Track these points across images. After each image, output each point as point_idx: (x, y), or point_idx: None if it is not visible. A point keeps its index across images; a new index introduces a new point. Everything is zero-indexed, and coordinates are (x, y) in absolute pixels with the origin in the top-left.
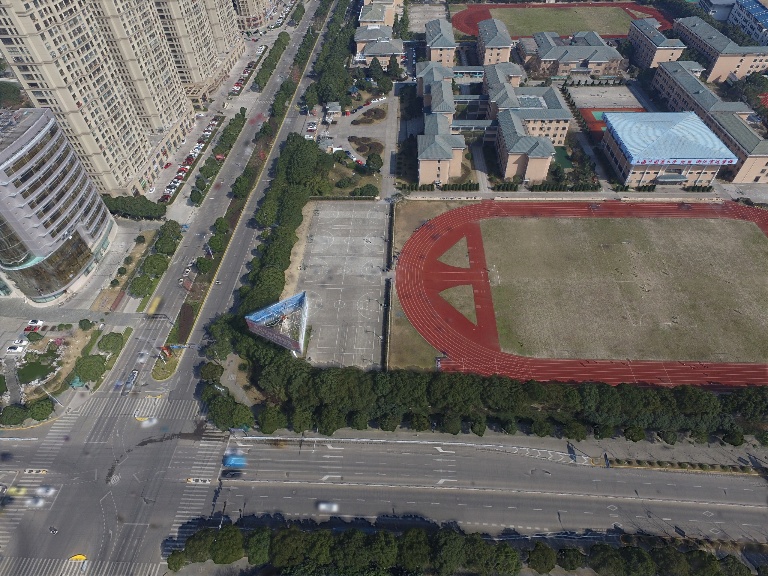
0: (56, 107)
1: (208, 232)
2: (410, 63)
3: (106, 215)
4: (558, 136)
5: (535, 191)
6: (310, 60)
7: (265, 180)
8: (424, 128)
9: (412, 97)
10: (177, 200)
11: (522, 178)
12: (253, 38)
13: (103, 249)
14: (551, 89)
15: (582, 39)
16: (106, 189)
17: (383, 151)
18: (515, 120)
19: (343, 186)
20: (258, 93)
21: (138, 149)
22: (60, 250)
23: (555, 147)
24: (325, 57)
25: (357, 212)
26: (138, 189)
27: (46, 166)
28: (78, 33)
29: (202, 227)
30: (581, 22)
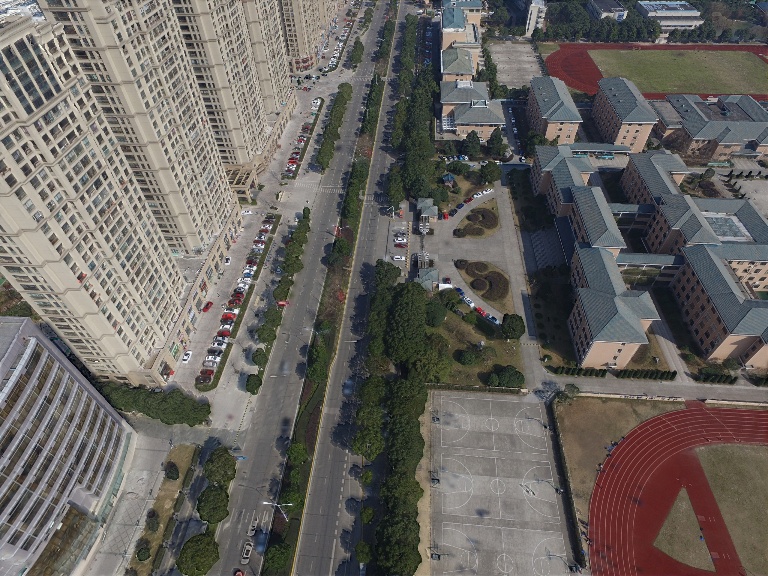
0: (44, 286)
1: (274, 453)
2: (510, 131)
3: (120, 438)
4: (767, 280)
5: (762, 386)
6: (380, 122)
7: (348, 341)
8: (569, 259)
9: (527, 190)
10: (224, 378)
11: (740, 364)
12: (304, 86)
13: (114, 493)
14: (748, 205)
15: (735, 106)
16: (121, 372)
17: (509, 290)
18: (719, 266)
19: (467, 363)
20: (320, 175)
21: (169, 300)
22: (41, 558)
23: (758, 292)
24: (403, 124)
25: (498, 419)
26: (167, 361)
27: (16, 439)
28: (83, 167)
29: (264, 441)
30: (711, 73)
